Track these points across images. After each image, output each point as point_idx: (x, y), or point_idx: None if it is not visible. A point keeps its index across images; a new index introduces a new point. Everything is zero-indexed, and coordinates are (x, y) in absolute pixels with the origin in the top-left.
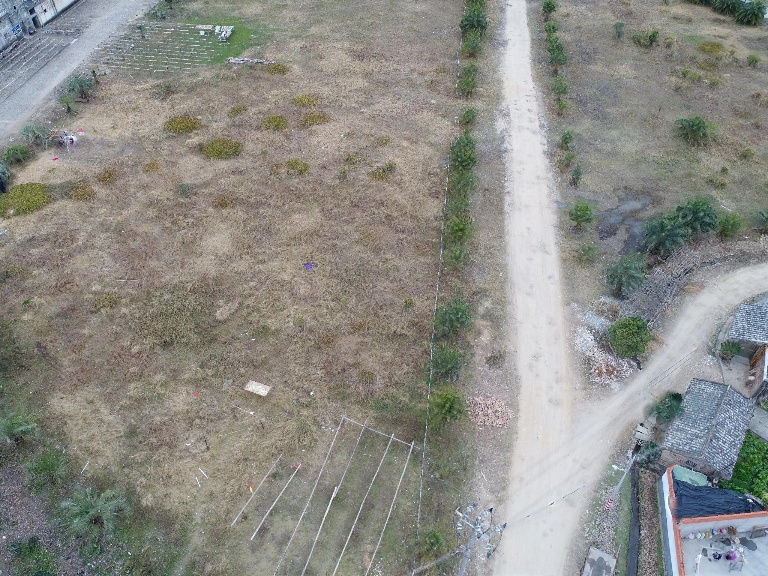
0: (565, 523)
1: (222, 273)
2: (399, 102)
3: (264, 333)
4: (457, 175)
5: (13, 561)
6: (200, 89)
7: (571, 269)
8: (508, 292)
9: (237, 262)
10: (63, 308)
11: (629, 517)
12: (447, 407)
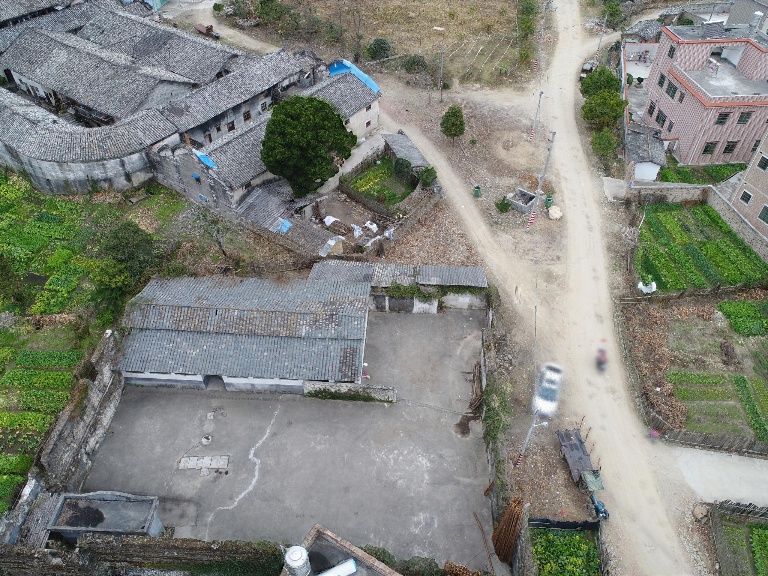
0: (579, 61)
1: (406, 6)
2: None
3: (434, 21)
4: None
5: (353, 63)
6: None
7: (585, 8)
8: (553, 13)
9: (413, 3)
10: (333, 13)
11: (606, 61)
12: (527, 27)
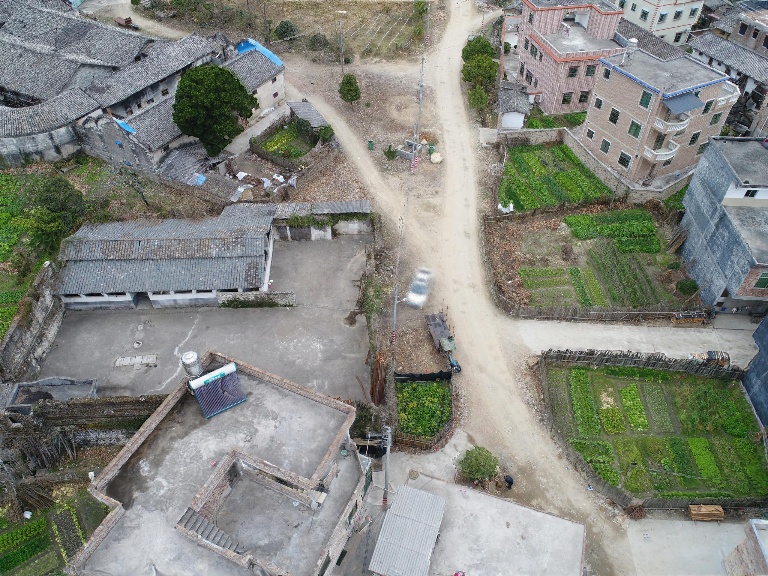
0: (467, 34)
1: None
2: None
3: (339, 6)
4: None
5: (264, 45)
6: None
7: None
8: None
9: None
10: (246, 3)
11: (491, 33)
12: (421, 7)
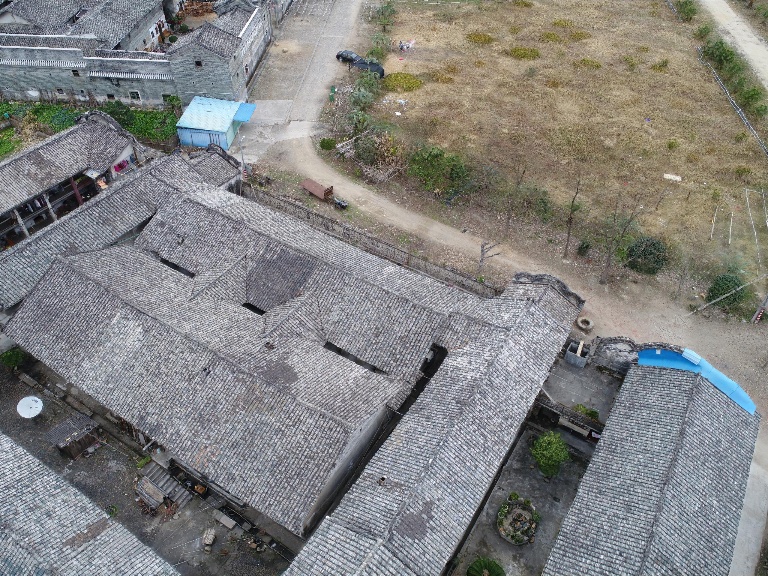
0: None
1: (588, 123)
2: (637, 25)
3: (645, 154)
4: (716, 69)
5: (577, 258)
6: (472, 17)
7: None
8: None
9: (594, 117)
10: (490, 141)
11: None
12: None
